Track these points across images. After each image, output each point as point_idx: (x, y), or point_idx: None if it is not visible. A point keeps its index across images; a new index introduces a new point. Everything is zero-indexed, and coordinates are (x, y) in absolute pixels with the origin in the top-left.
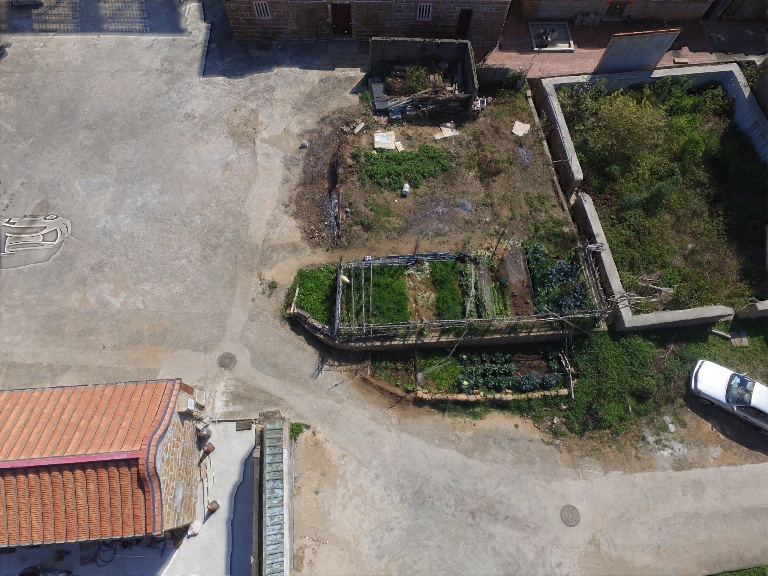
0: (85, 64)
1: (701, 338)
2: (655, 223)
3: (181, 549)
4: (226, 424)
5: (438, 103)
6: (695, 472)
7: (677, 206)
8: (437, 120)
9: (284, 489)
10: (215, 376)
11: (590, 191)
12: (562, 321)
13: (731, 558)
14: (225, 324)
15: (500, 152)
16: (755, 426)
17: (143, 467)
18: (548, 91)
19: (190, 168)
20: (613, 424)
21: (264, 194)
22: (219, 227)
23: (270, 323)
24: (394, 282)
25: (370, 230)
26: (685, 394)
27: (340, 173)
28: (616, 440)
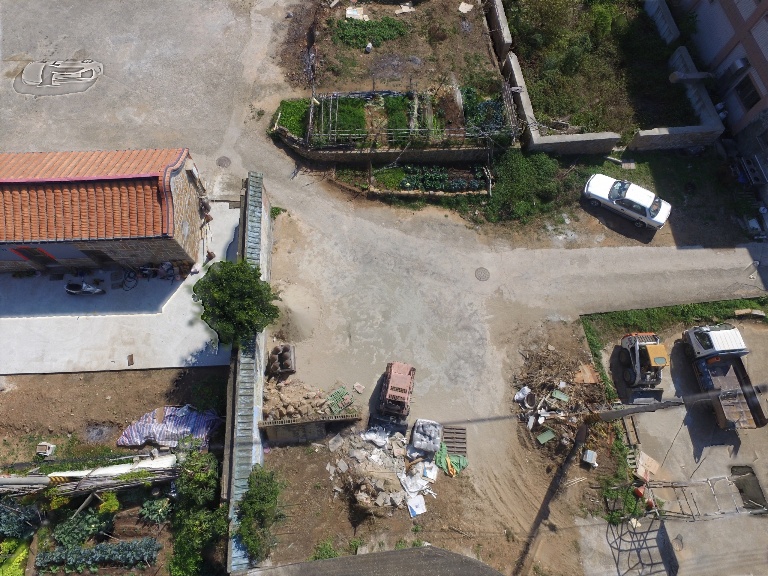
0: None
1: (598, 162)
2: (570, 81)
3: (186, 281)
4: (222, 203)
5: None
6: (582, 250)
7: (589, 70)
8: None
9: (263, 233)
10: (214, 171)
11: (520, 57)
12: (485, 139)
13: (602, 304)
14: (223, 138)
15: (447, 24)
16: (631, 219)
17: (161, 182)
18: None
19: (198, 30)
20: (521, 215)
21: (256, 49)
22: (220, 71)
23: (258, 139)
24: (356, 110)
25: (339, 75)
26: (580, 198)
27: (317, 35)
28: (523, 227)
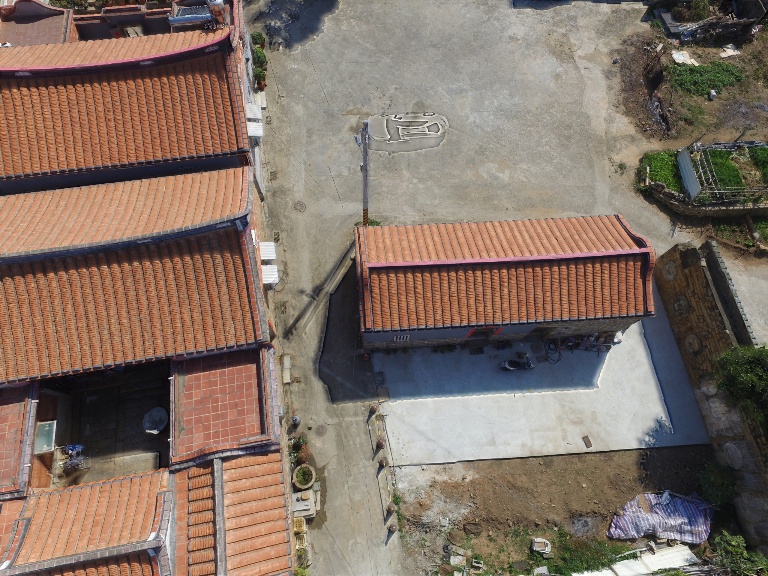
0: None
1: None
2: None
3: (611, 353)
4: None
5: (726, 27)
6: None
7: None
8: (720, 43)
9: None
10: None
11: None
12: None
13: None
14: (594, 194)
15: None
16: None
17: (653, 259)
18: None
19: (528, 78)
20: None
21: (596, 98)
22: (567, 122)
23: (628, 195)
24: None
25: (693, 125)
26: None
27: None
28: None
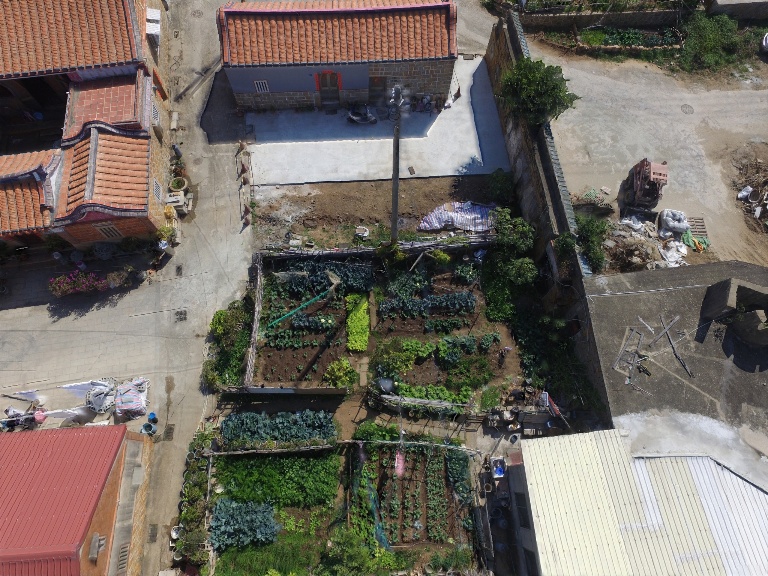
0: None
1: (767, 25)
2: None
3: (441, 114)
4: None
5: None
6: (767, 91)
7: None
8: None
9: None
10: None
11: None
12: (675, 1)
13: None
14: None
15: None
16: None
17: (452, 9)
18: None
19: None
20: (711, 64)
21: None
22: None
23: (474, 8)
24: None
25: None
26: (758, 52)
27: None
28: (714, 74)
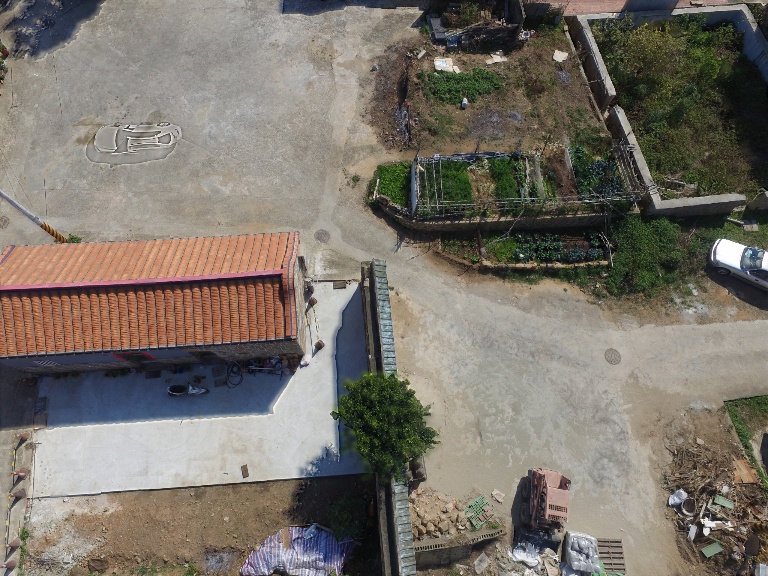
0: (180, 3)
1: (718, 224)
2: (677, 134)
3: (296, 376)
4: (325, 284)
5: (490, 33)
6: (715, 325)
7: (695, 121)
8: (488, 49)
9: None
10: (313, 247)
11: None
12: (602, 204)
13: (746, 388)
14: (318, 208)
15: (543, 74)
16: (765, 289)
17: (286, 281)
18: (583, 25)
19: (278, 86)
20: (646, 288)
21: (344, 107)
22: (307, 133)
23: (355, 208)
24: (459, 174)
25: (436, 135)
26: (706, 266)
27: (408, 90)
28: (649, 301)
